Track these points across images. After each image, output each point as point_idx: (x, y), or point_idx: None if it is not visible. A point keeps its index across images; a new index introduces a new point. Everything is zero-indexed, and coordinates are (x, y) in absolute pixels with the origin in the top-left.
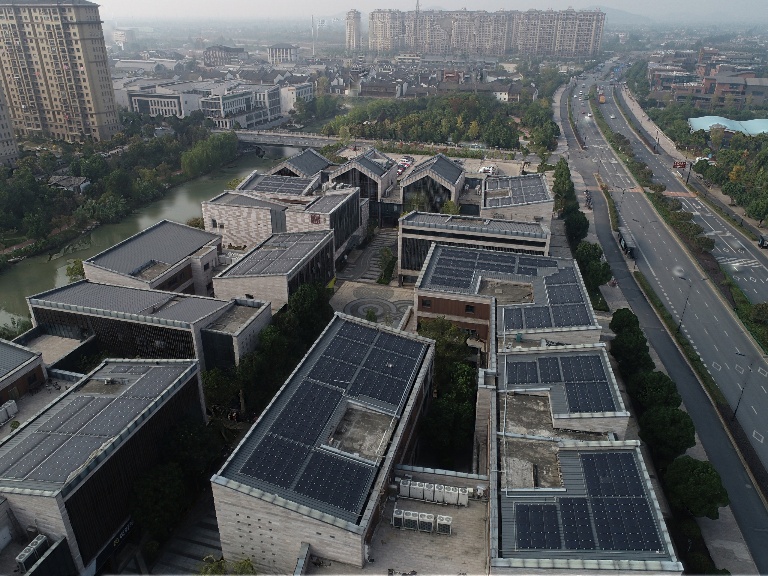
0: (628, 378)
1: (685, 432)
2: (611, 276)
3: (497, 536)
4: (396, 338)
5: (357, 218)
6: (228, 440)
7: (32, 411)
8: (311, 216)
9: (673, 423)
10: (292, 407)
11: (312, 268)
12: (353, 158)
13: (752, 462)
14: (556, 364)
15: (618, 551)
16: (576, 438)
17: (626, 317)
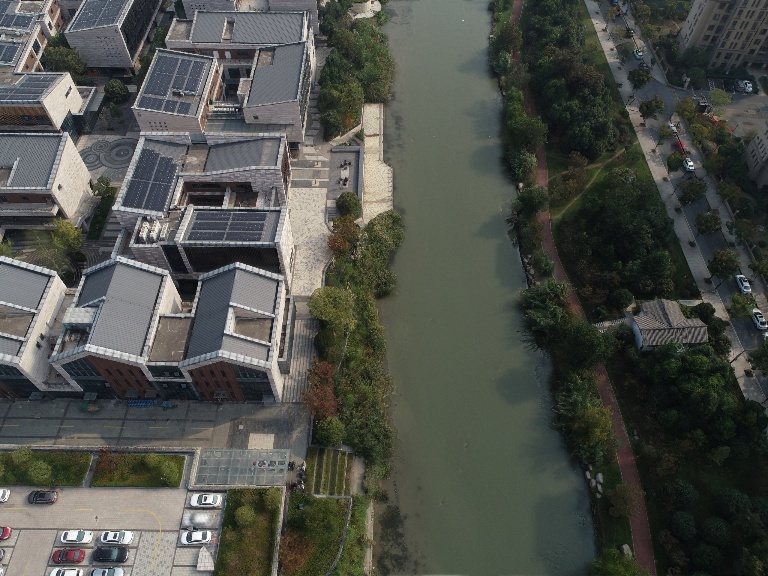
0: None
1: None
2: None
3: None
4: None
5: None
6: None
7: (261, 2)
8: None
9: None
10: None
11: None
12: None
13: None
14: (3, 22)
15: None
16: None
17: None
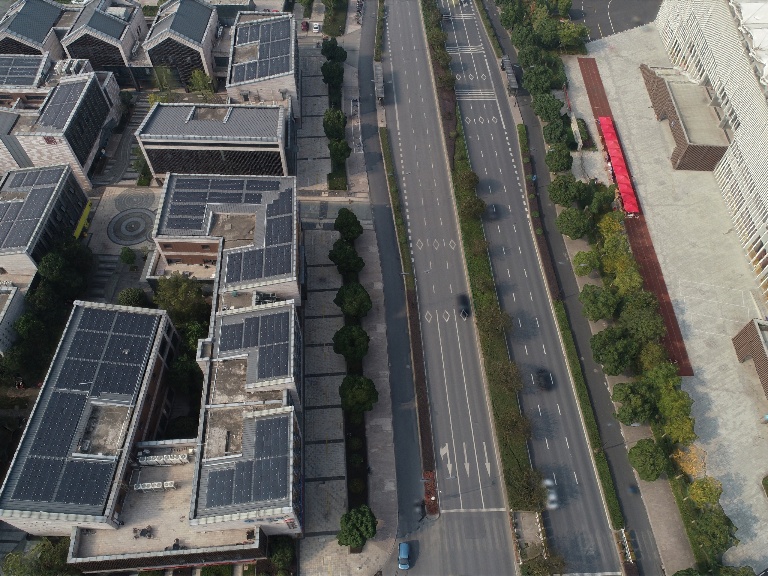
0: (345, 277)
1: (358, 349)
2: (349, 153)
3: (195, 501)
4: (132, 317)
5: (103, 104)
6: (13, 430)
7: None
8: (44, 138)
9: (353, 340)
10: (45, 424)
11: (56, 218)
12: (87, 2)
13: (414, 346)
14: (257, 325)
15: (262, 501)
16: (261, 398)
17: (345, 219)
